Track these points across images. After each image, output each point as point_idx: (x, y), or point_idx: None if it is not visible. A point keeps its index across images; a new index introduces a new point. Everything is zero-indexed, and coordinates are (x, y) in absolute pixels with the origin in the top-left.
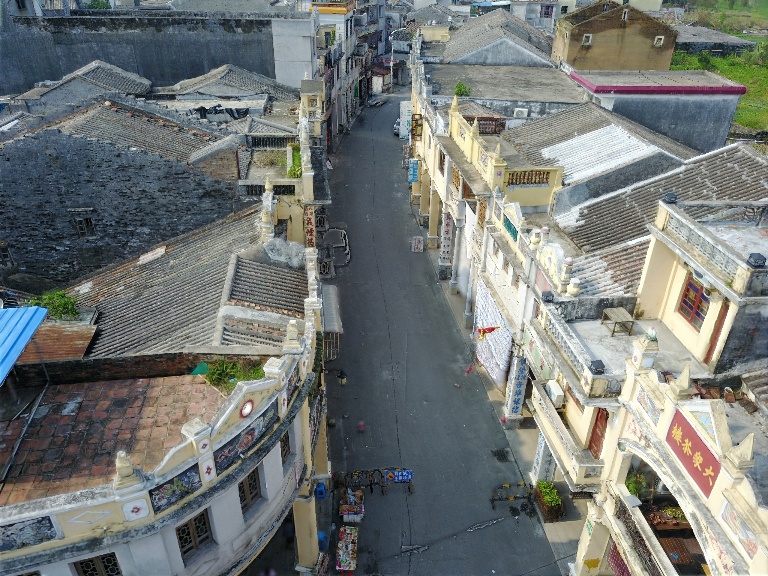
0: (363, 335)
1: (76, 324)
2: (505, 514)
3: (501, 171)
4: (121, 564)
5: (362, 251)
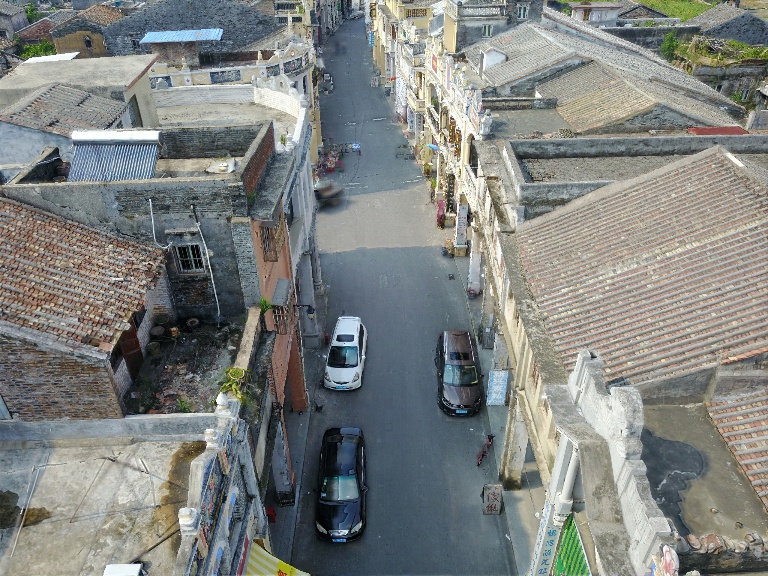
0: (340, 116)
1: None
2: (402, 159)
3: (402, 9)
4: None
5: (341, 87)
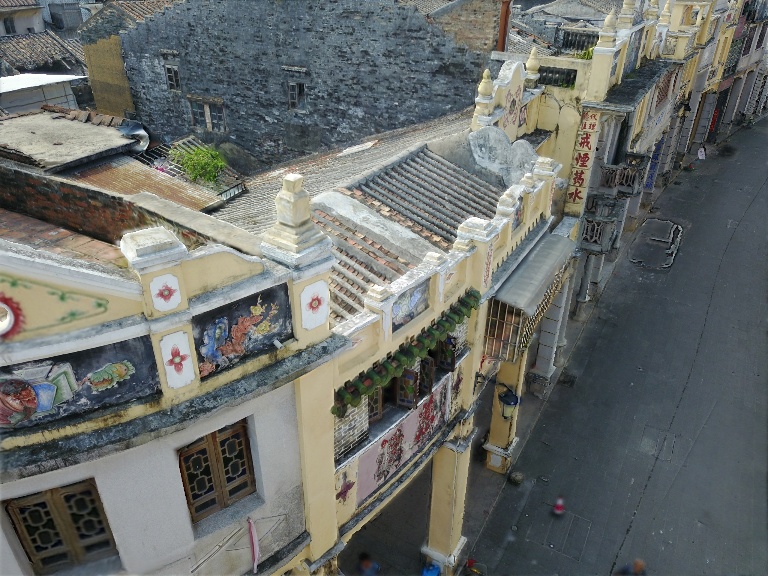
0: (640, 371)
1: (202, 190)
2: None
3: None
4: None
5: (698, 261)
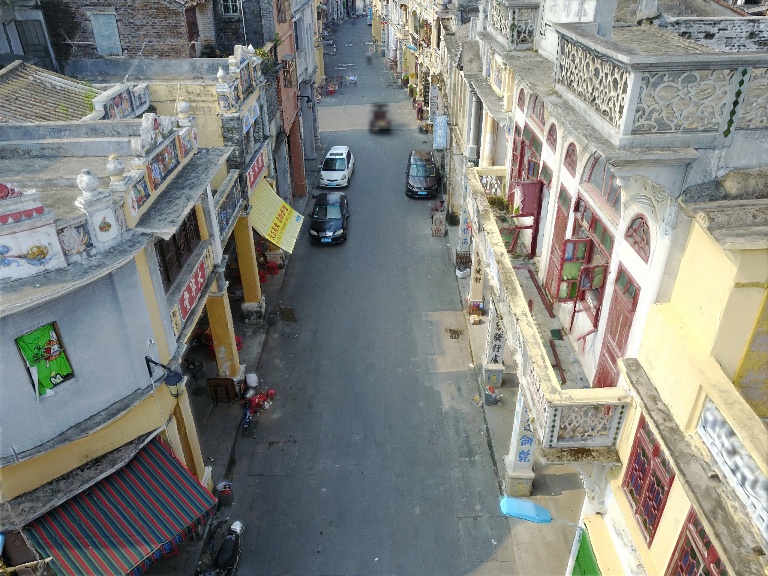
0: None
1: None
2: None
3: None
4: None
5: (343, 53)
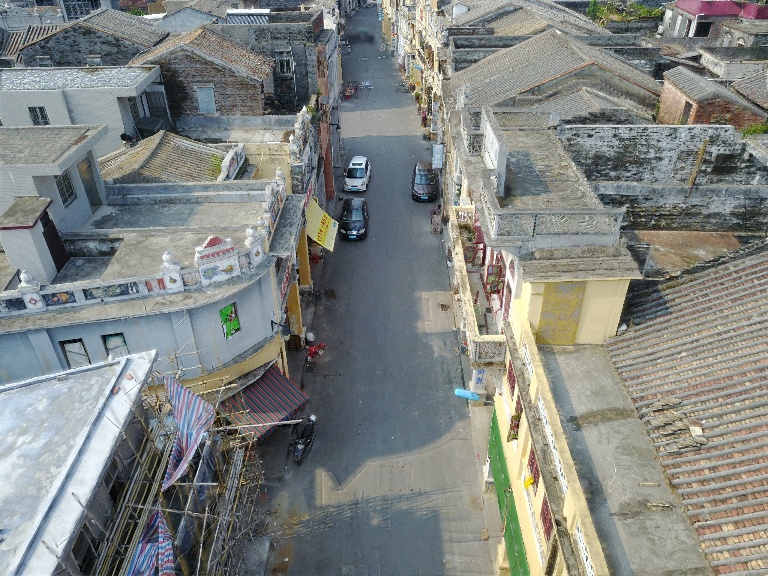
0: None
1: None
2: None
3: None
4: None
5: (356, 52)
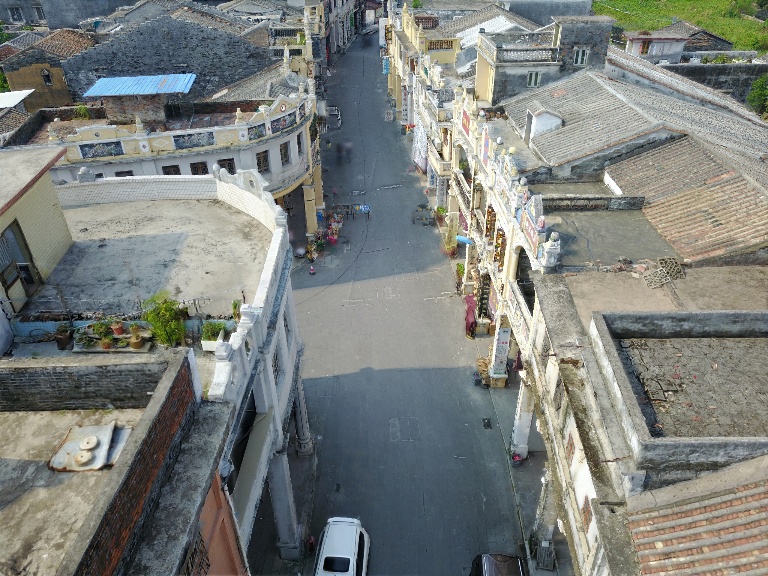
0: (348, 161)
1: None
2: (420, 225)
3: (423, 40)
4: (236, 165)
5: (350, 122)
